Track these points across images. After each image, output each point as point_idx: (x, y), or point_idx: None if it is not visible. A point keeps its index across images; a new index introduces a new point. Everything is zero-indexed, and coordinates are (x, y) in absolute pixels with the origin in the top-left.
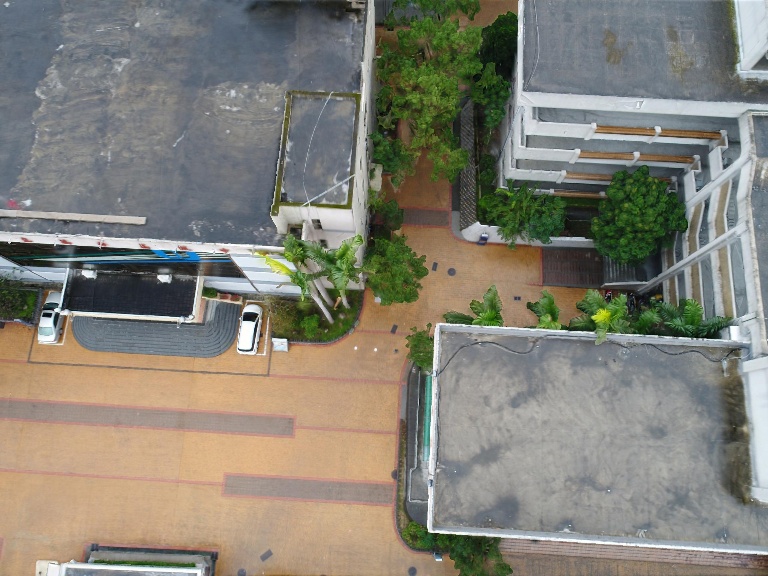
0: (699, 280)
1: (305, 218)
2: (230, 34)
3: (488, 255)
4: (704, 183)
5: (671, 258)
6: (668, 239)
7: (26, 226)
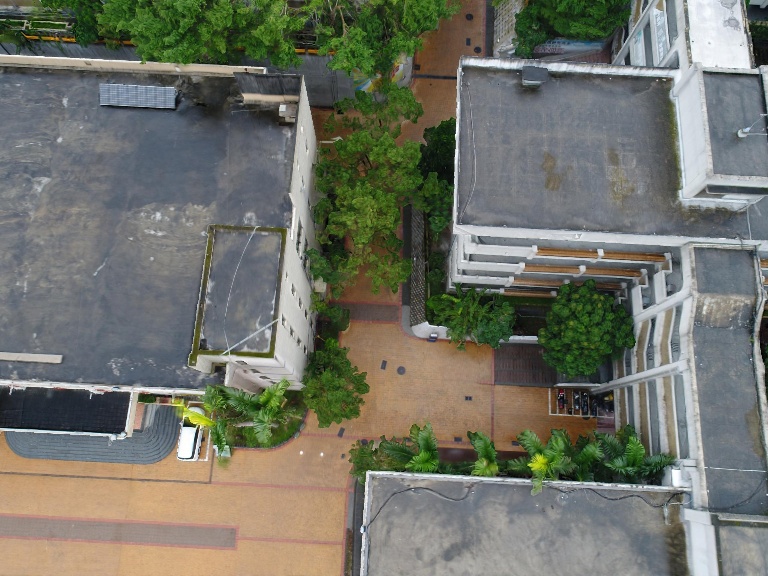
0: (646, 401)
1: (228, 361)
2: (157, 150)
3: (439, 352)
4: (650, 302)
5: (621, 367)
6: (617, 351)
7: None
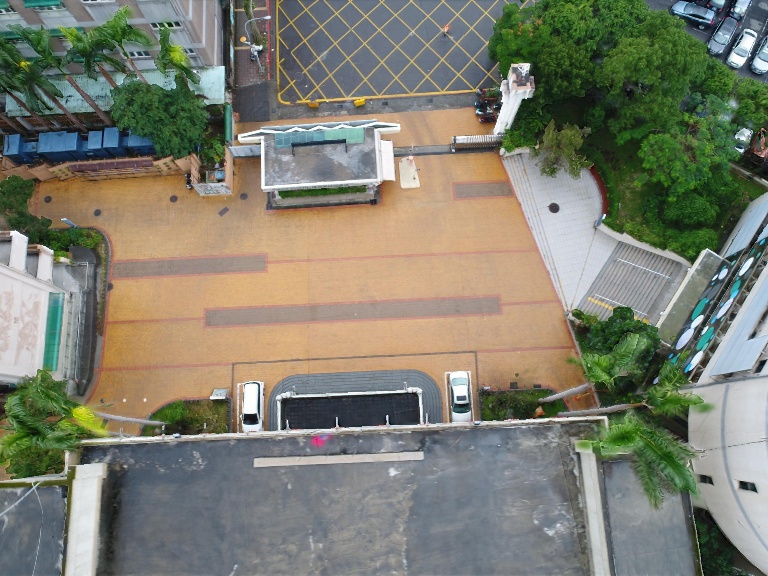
0: None
1: None
2: None
3: None
4: None
5: None
6: None
7: (387, 443)
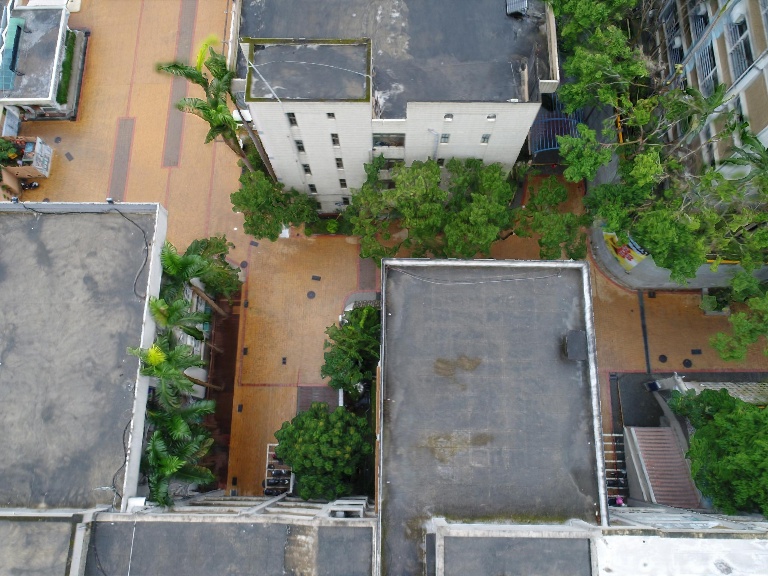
0: None
1: None
2: (463, 6)
3: None
4: None
5: None
6: None
7: None
